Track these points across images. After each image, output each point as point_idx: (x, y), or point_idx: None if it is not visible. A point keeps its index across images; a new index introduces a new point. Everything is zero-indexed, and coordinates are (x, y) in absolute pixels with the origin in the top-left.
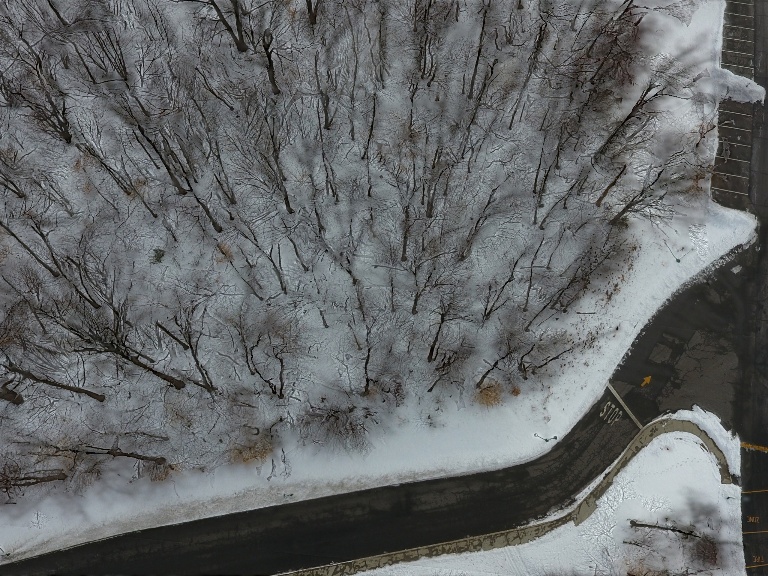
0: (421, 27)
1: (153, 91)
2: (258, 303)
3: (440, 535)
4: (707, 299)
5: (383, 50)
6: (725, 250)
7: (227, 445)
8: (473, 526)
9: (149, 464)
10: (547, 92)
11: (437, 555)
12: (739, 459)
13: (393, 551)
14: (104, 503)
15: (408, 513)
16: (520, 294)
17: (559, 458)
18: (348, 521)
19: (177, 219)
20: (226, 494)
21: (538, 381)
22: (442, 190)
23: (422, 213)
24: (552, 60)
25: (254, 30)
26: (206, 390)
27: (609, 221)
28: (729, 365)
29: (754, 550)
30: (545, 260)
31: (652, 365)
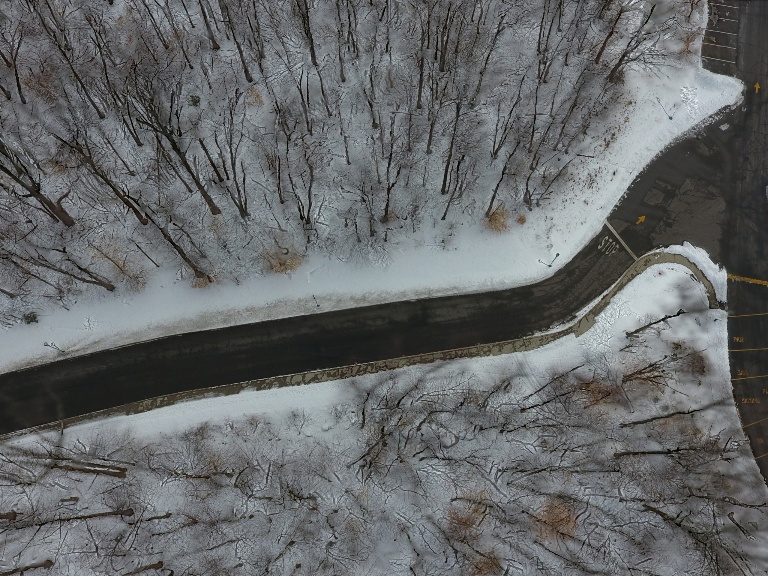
0: None
1: None
2: None
3: (453, 343)
4: (697, 152)
5: None
6: (714, 110)
7: (261, 252)
8: (483, 336)
9: (190, 273)
10: None
11: (451, 359)
12: (726, 288)
13: (411, 355)
14: (149, 310)
15: (424, 324)
16: (525, 136)
17: (561, 282)
18: (370, 329)
19: (212, 65)
20: (259, 304)
21: (542, 212)
22: (454, 46)
23: (435, 66)
24: None
25: None
26: (240, 216)
27: (607, 76)
28: (717, 208)
29: (739, 365)
30: (548, 107)
31: (646, 206)
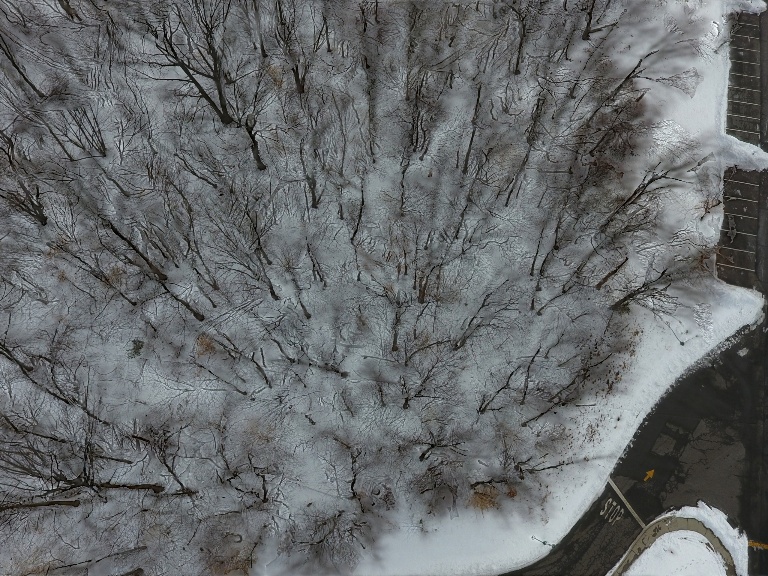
0: (413, 95)
1: (133, 169)
2: (241, 398)
3: None
4: (712, 385)
5: (374, 122)
6: (731, 331)
7: (207, 561)
8: None
9: None
10: (545, 166)
11: None
12: (746, 559)
13: None
14: None
15: None
16: (516, 387)
17: (558, 562)
18: None
19: (156, 311)
20: None
21: (535, 480)
22: (435, 275)
23: (414, 299)
24: (550, 130)
25: (239, 101)
26: (186, 494)
27: (610, 306)
28: (736, 456)
29: None
30: None
31: (655, 458)
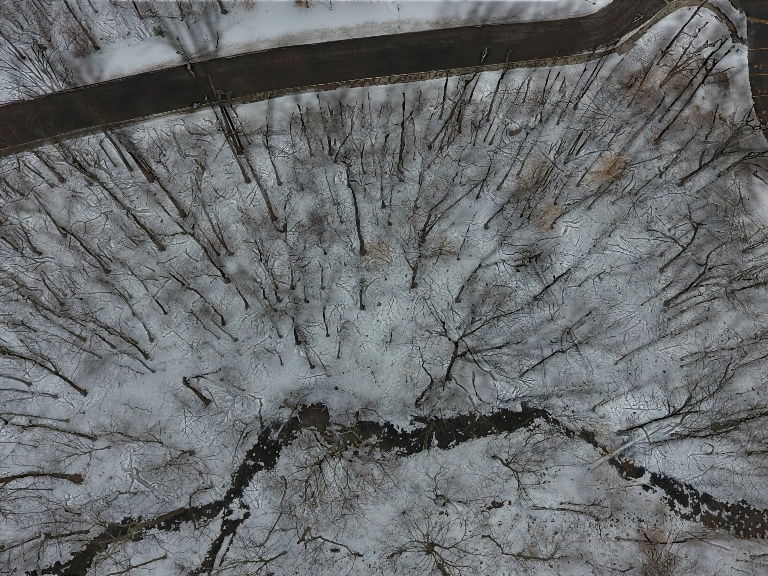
0: None
1: None
2: None
3: (514, 58)
4: None
5: None
6: None
7: None
8: (539, 53)
9: None
10: None
11: (513, 68)
12: (746, 27)
13: (479, 65)
14: (257, 28)
15: (489, 43)
16: None
17: (604, 17)
18: (443, 47)
19: None
20: (349, 25)
21: None
22: None
23: None
24: None
25: None
26: None
27: None
28: None
29: (759, 86)
30: None
31: None
